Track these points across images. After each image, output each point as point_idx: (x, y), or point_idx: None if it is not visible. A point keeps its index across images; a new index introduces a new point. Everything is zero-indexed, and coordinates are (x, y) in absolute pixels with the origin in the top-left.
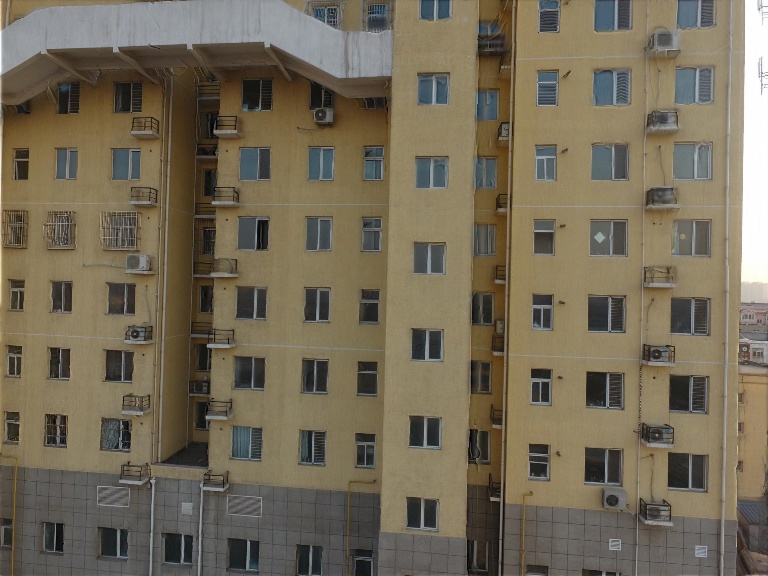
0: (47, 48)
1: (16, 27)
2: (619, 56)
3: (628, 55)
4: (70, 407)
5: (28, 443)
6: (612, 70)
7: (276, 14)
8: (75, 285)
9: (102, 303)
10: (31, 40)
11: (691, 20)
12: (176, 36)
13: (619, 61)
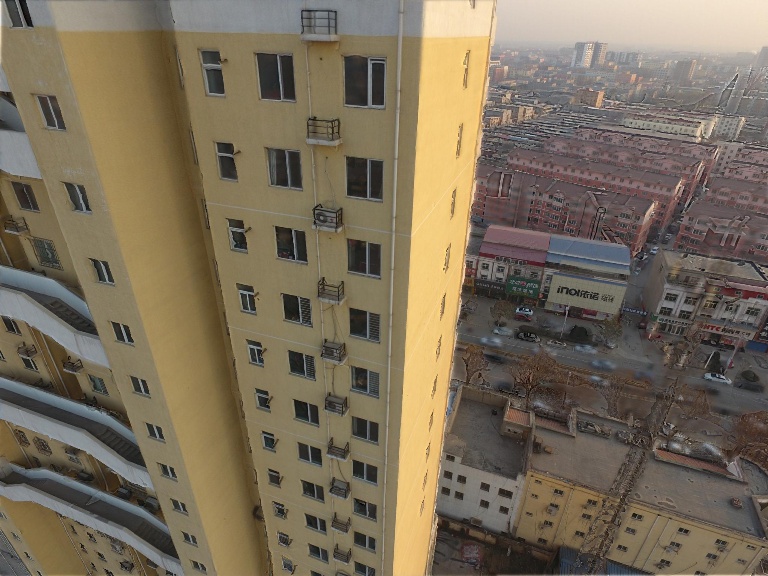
0: (33, 501)
1: (16, 489)
2: (323, 571)
3: (328, 572)
4: (112, 571)
5: (101, 573)
6: (320, 573)
7: (126, 537)
8: (95, 537)
9: (109, 546)
10: (25, 496)
11: (364, 571)
12: (86, 523)
13: (323, 572)
